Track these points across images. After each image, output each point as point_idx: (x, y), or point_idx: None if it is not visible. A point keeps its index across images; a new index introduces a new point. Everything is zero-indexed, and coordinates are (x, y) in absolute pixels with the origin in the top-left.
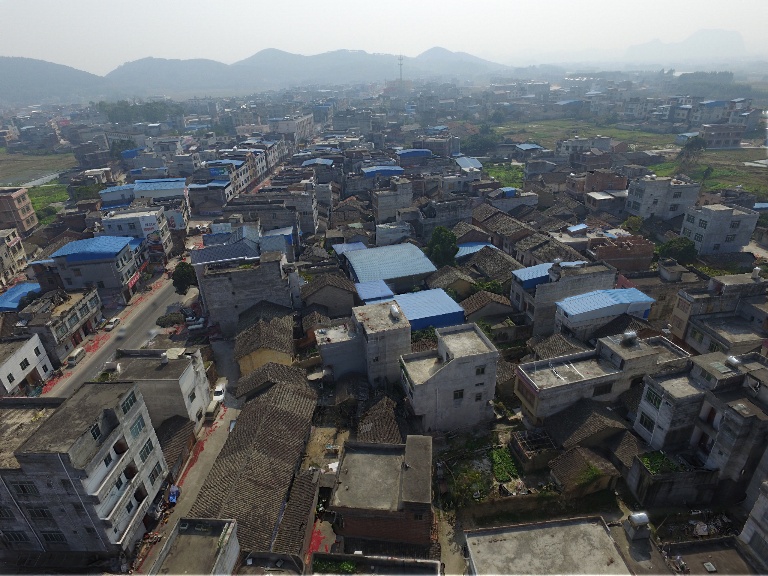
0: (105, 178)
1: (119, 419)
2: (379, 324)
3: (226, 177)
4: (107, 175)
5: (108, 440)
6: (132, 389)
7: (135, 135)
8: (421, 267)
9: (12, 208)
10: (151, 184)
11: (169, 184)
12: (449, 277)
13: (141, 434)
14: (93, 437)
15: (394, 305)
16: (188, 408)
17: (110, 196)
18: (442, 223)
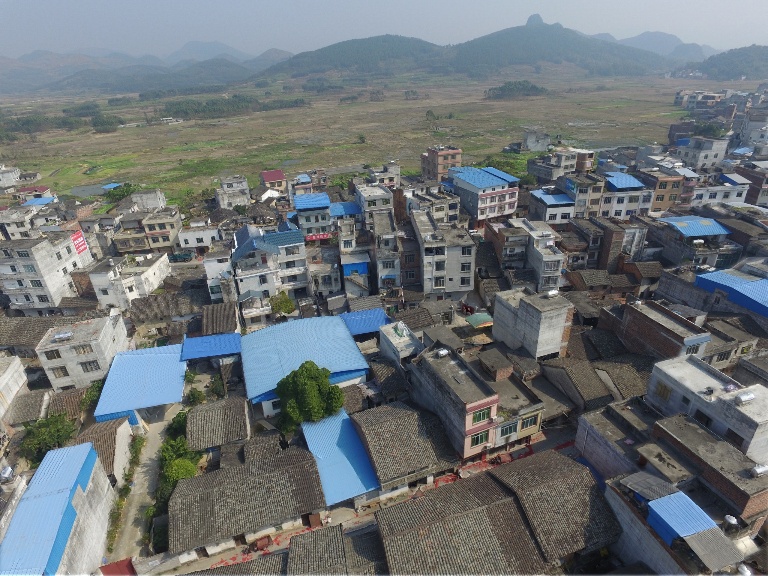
0: (576, 160)
1: (14, 256)
2: (59, 332)
3: (574, 195)
4: (582, 158)
5: (4, 259)
6: (26, 250)
7: (751, 121)
8: (260, 381)
9: (437, 162)
10: (481, 174)
11: (488, 179)
12: (209, 408)
13: (32, 273)
14: (4, 254)
15: (69, 332)
16: (98, 295)
17: (452, 174)
18: (429, 394)
